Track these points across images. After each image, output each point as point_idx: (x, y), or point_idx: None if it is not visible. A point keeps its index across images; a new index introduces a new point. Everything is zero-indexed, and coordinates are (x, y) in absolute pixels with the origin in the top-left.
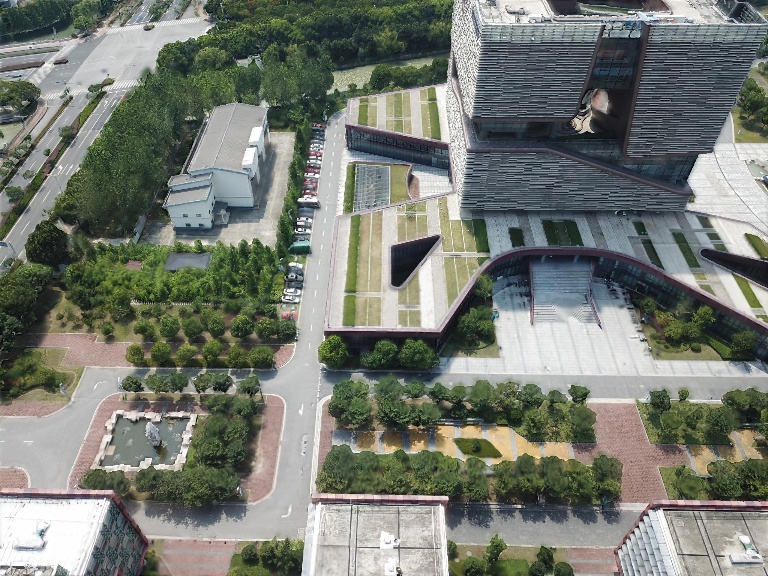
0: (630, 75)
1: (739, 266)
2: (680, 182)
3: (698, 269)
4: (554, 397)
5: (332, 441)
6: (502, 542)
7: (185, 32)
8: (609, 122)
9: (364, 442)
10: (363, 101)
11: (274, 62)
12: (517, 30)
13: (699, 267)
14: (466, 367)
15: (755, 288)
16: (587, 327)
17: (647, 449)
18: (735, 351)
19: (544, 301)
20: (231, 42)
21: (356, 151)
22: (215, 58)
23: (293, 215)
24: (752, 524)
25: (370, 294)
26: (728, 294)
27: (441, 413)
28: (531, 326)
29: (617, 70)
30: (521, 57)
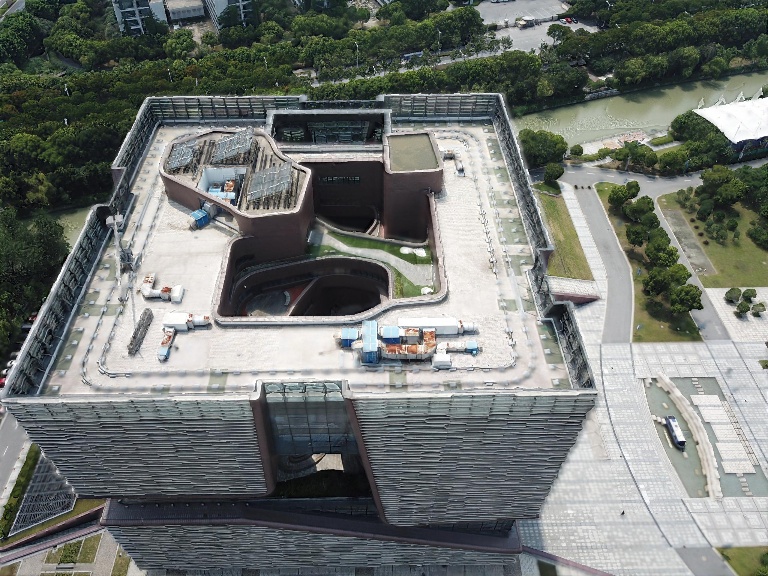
0: (353, 440)
1: None
2: None
3: None
4: None
5: None
6: None
7: None
8: None
9: None
10: None
11: (9, 201)
12: (79, 406)
13: None
14: None
15: None
16: None
17: None
18: None
19: None
20: None
21: None
22: None
23: None
24: None
25: None
26: None
27: None
28: None
29: (324, 435)
30: (114, 436)
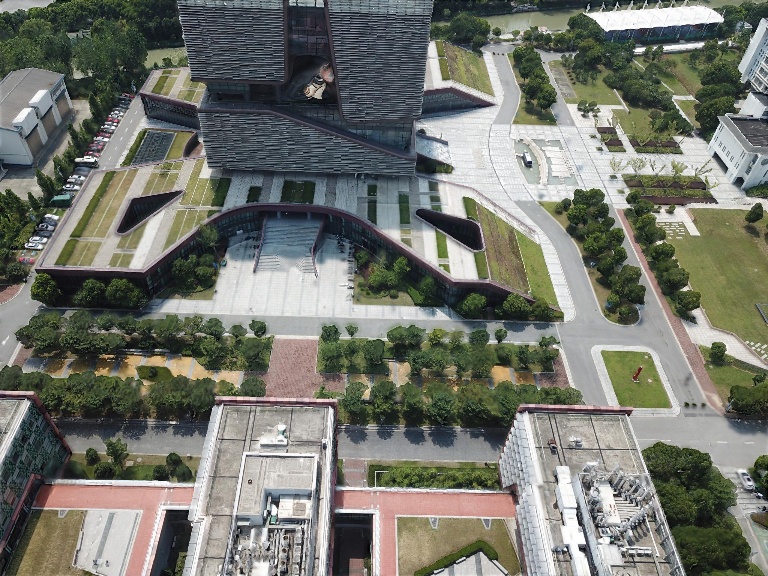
0: (327, 43)
1: (452, 225)
2: (408, 148)
3: (407, 225)
4: (234, 330)
5: (22, 367)
6: (123, 445)
7: (32, 6)
8: (331, 89)
9: (51, 368)
10: (165, 72)
11: None
12: None
13: (409, 224)
14: (177, 307)
15: (450, 242)
16: (304, 276)
17: (311, 377)
18: (427, 298)
19: (270, 252)
20: (61, 15)
21: (154, 119)
22: (39, 29)
23: (64, 172)
24: (296, 416)
25: (93, 239)
26: (424, 246)
27: (132, 344)
28: (253, 274)
29: (314, 37)
30: (219, 21)
